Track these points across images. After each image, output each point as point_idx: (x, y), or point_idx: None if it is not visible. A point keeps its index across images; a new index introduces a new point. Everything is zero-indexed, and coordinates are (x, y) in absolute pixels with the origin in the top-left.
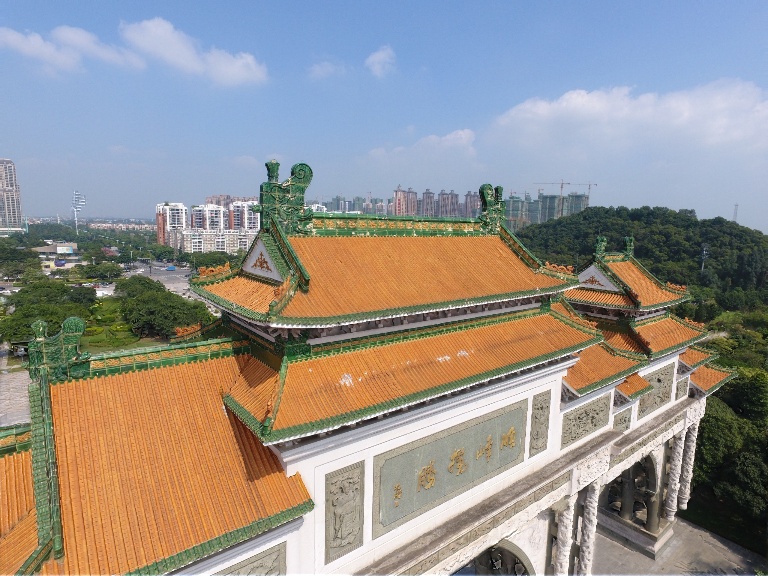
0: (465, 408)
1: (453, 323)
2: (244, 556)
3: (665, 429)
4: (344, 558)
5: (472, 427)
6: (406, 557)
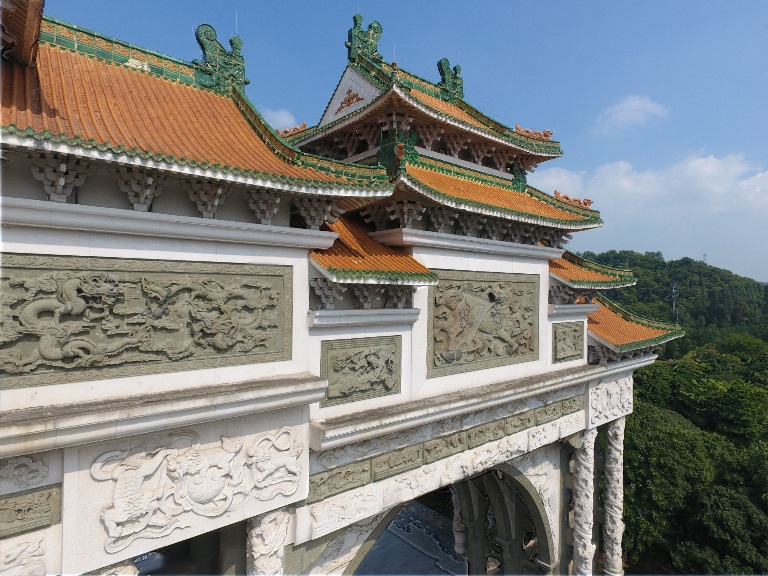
0: None
1: None
2: None
3: (534, 421)
4: None
5: None
6: None
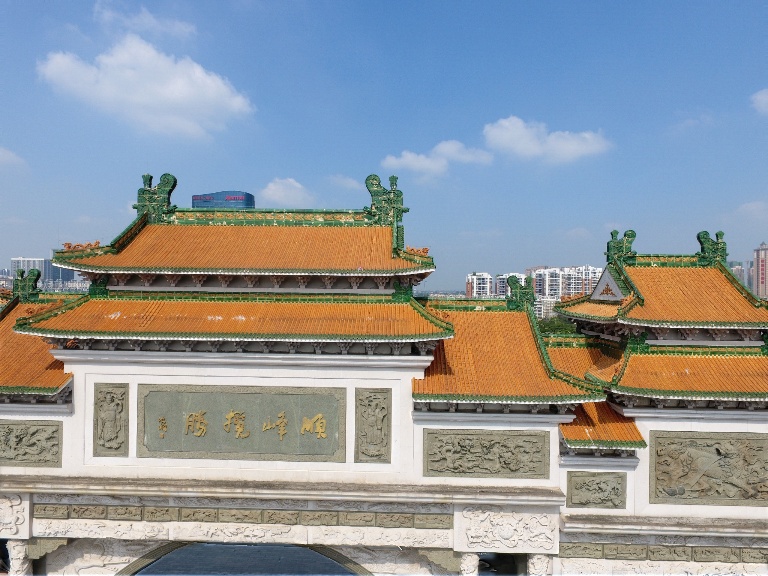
0: (244, 372)
1: (252, 293)
2: (33, 417)
3: None
4: (110, 459)
5: (255, 394)
6: (156, 484)
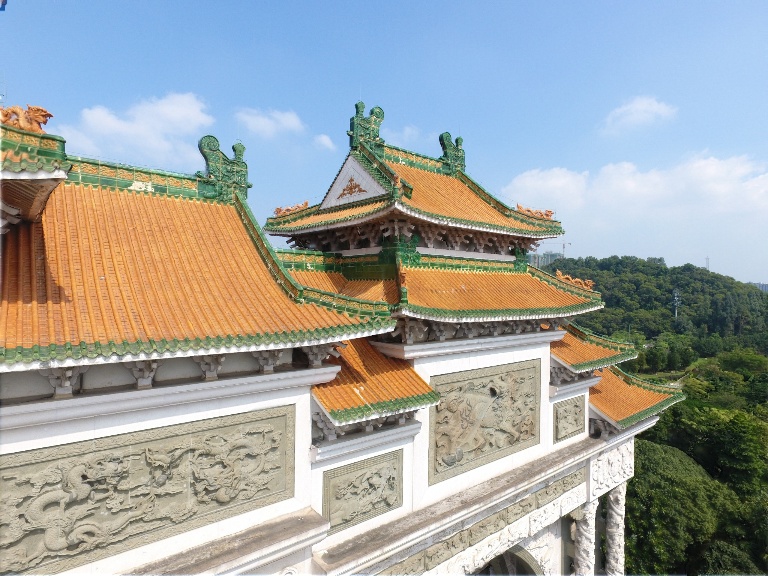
0: None
1: None
2: None
3: (536, 503)
4: None
5: None
6: None
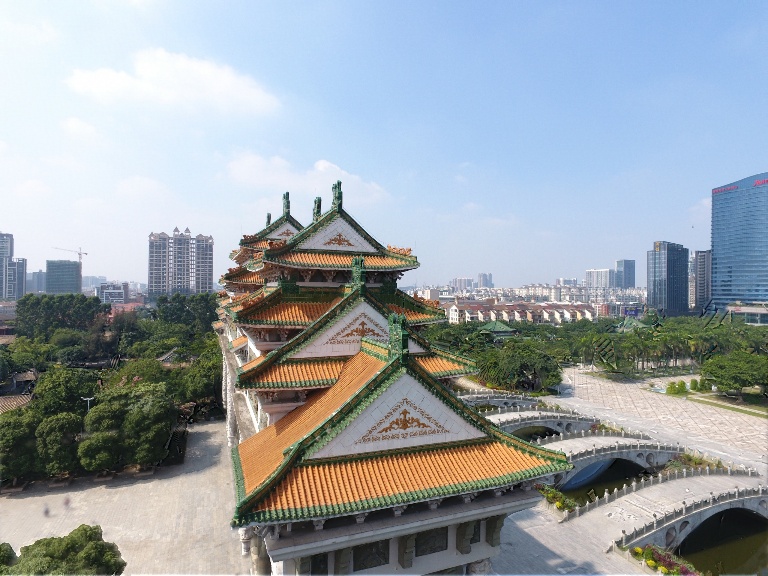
0: None
1: None
2: None
3: None
4: None
5: None
6: None
